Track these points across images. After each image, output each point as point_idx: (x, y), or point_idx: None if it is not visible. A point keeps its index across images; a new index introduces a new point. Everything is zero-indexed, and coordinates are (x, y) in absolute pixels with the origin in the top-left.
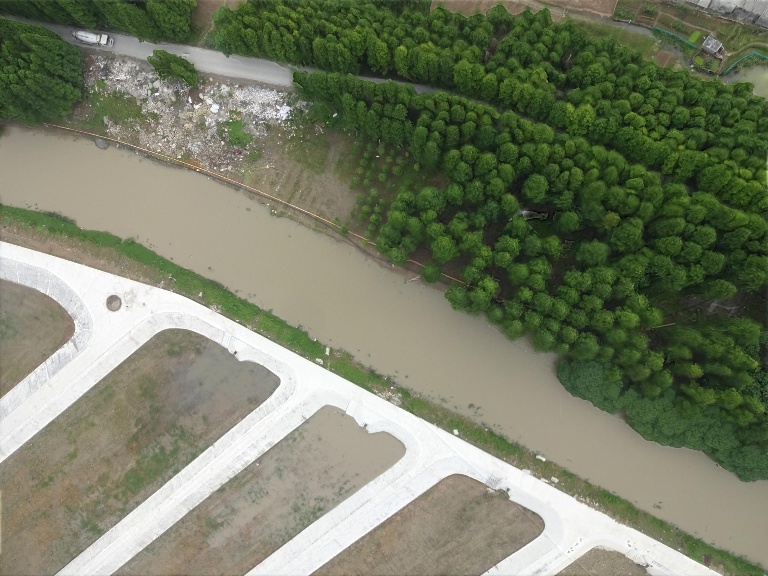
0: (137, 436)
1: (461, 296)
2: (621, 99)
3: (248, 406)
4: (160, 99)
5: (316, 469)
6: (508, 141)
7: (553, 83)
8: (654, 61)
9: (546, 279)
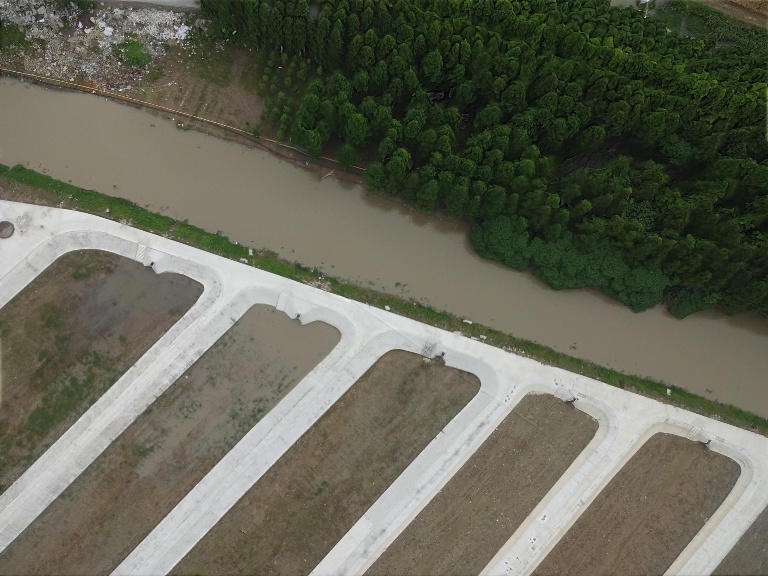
0: (42, 371)
1: (379, 167)
2: None
3: (170, 318)
4: (46, 25)
5: (251, 370)
6: (404, 23)
7: None
8: None
9: (451, 146)
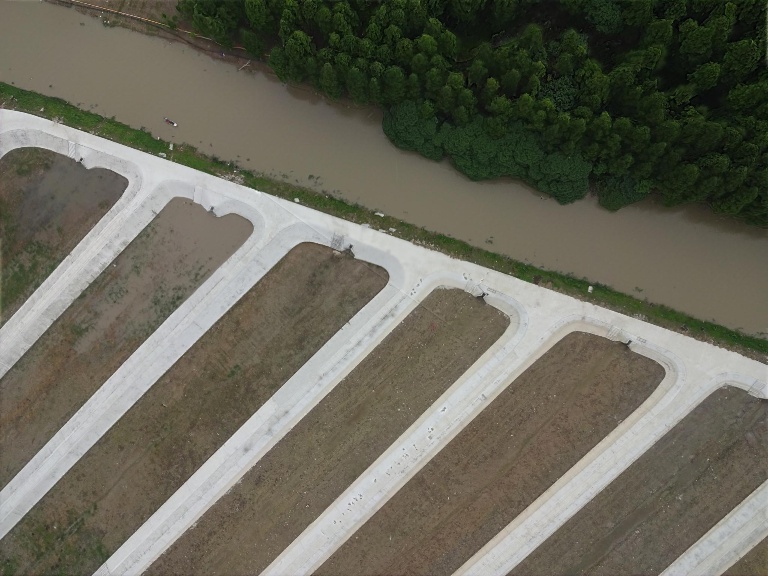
0: None
1: (276, 52)
2: None
3: (100, 211)
4: None
5: (171, 260)
6: None
7: None
8: None
9: (352, 25)
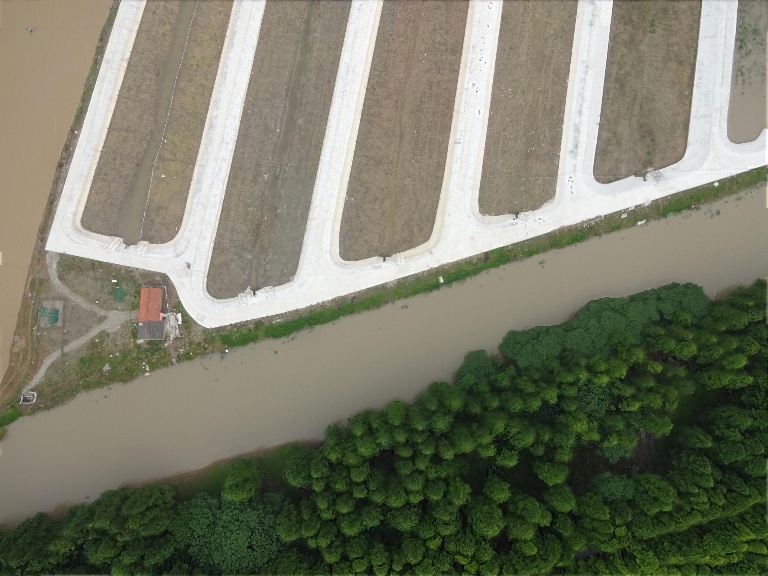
0: None
1: None
2: None
3: None
4: None
5: None
6: None
7: None
8: None
9: None
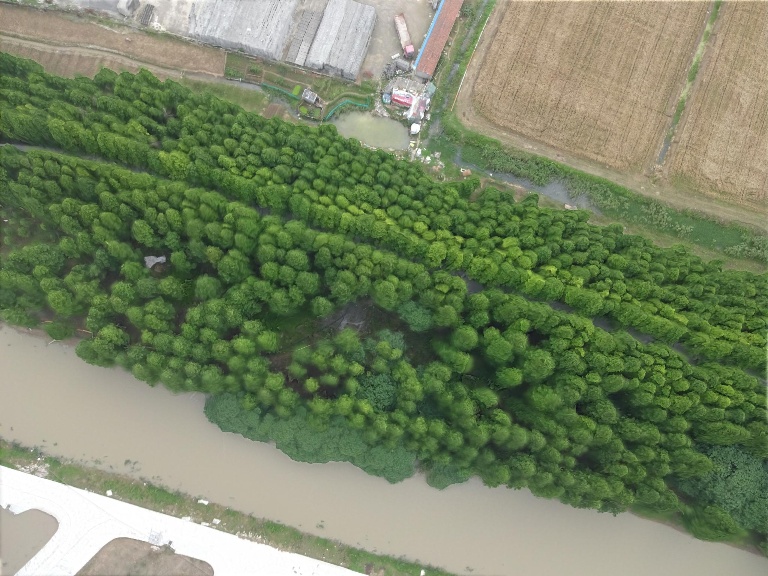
0: None
1: (82, 348)
2: (217, 145)
3: None
4: None
5: None
6: (104, 190)
7: (155, 135)
8: (266, 113)
9: (168, 319)
